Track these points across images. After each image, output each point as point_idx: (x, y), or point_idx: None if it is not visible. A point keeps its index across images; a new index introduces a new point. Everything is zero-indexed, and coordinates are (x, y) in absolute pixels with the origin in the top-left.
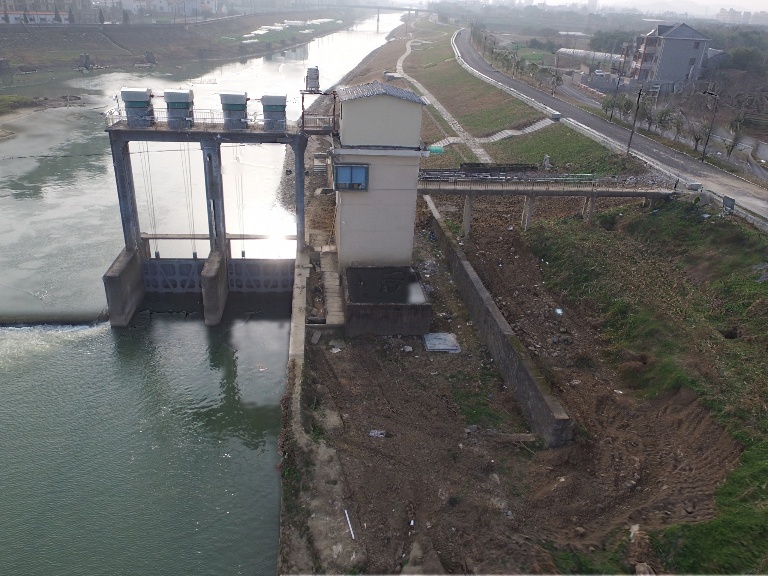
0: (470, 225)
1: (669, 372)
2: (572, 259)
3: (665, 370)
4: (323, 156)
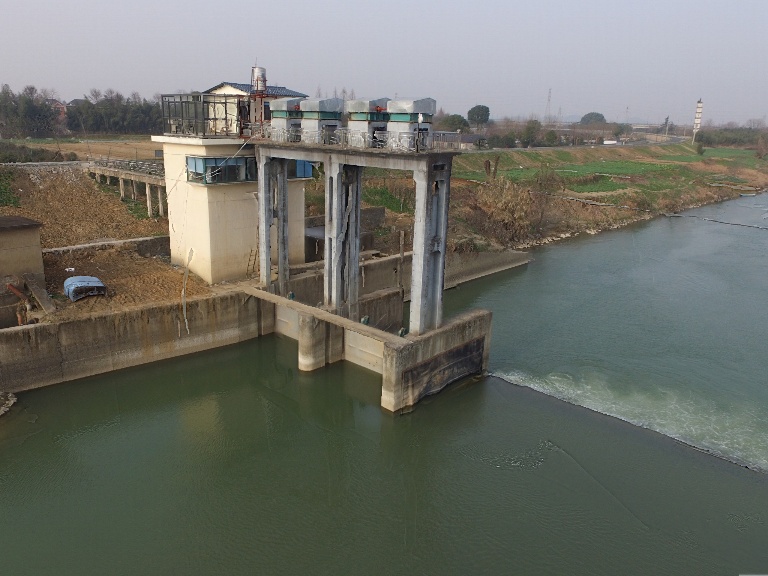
0: (151, 233)
1: None
2: None
3: None
4: None
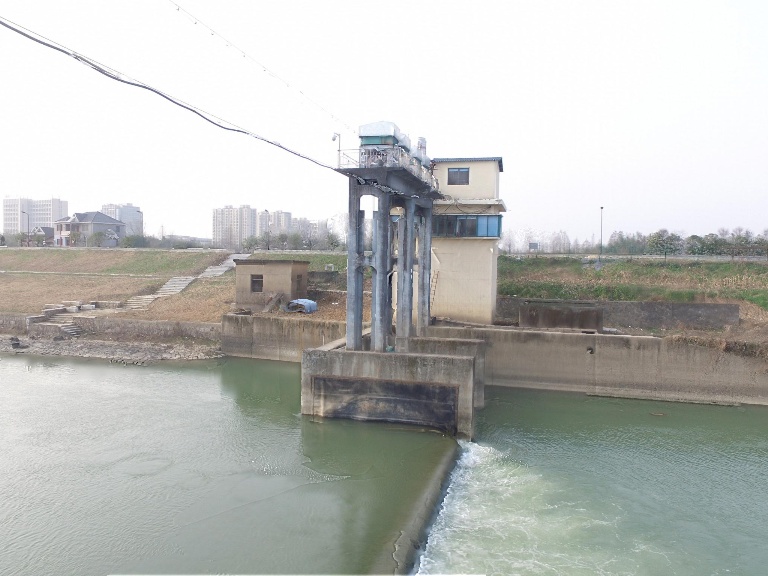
0: None
1: (680, 294)
2: (531, 286)
3: (676, 295)
4: (41, 319)
